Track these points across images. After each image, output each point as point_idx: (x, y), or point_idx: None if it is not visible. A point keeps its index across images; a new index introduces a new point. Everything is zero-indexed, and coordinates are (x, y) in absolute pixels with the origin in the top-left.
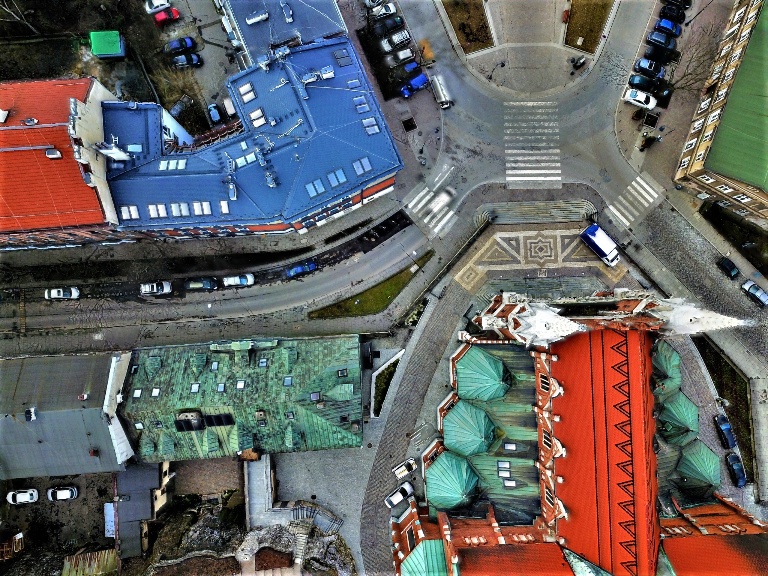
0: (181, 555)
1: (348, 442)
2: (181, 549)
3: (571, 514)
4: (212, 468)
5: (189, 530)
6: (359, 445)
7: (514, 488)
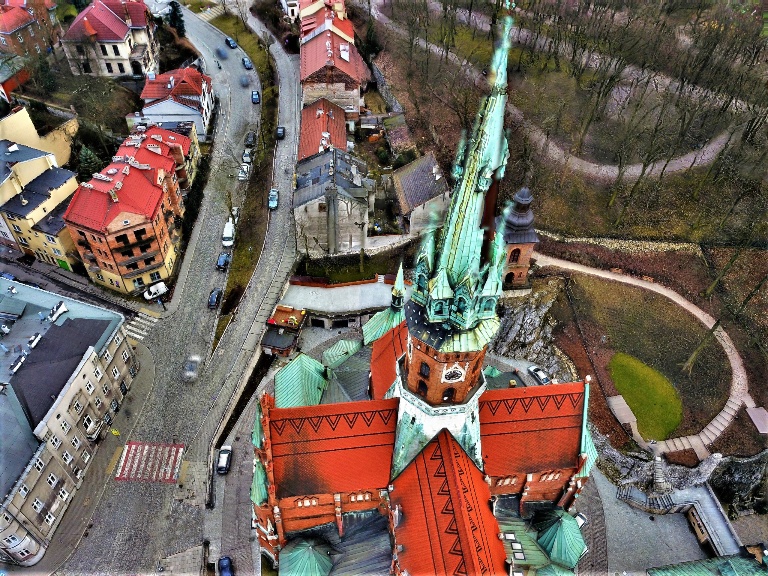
0: (764, 457)
1: (664, 572)
2: (765, 462)
3: (486, 502)
4: (759, 540)
5: (761, 479)
6: (650, 570)
7: (506, 532)
